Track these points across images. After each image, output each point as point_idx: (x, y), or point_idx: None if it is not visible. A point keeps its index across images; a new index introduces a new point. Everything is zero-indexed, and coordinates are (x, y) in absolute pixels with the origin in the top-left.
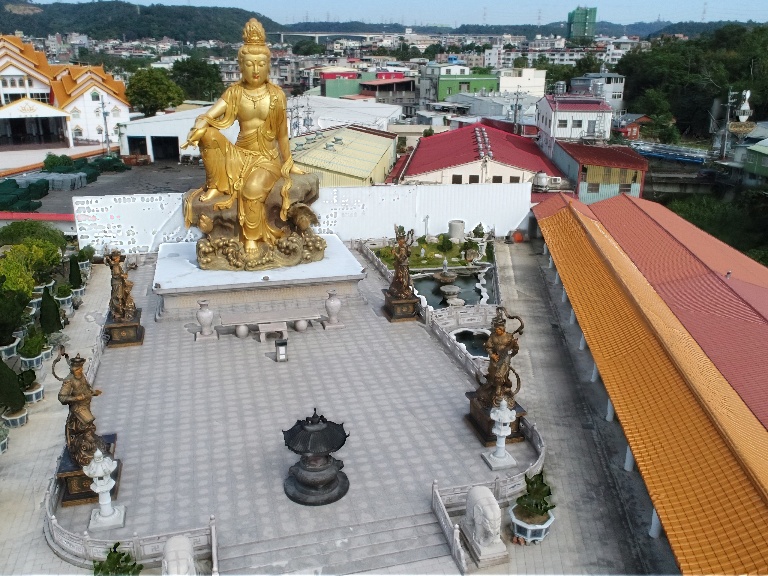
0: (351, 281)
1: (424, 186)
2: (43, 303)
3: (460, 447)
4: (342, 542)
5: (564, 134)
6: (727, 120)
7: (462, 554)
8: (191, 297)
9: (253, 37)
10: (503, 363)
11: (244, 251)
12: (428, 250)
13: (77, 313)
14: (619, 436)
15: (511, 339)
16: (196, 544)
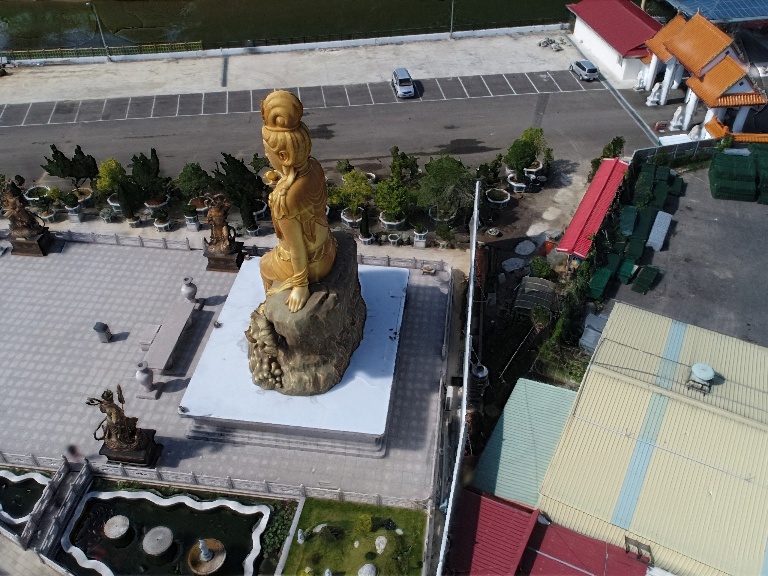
0: None
1: (438, 575)
2: None
3: None
4: None
5: None
6: None
7: None
8: None
9: None
10: None
11: None
12: None
13: None
14: None
15: None
16: None
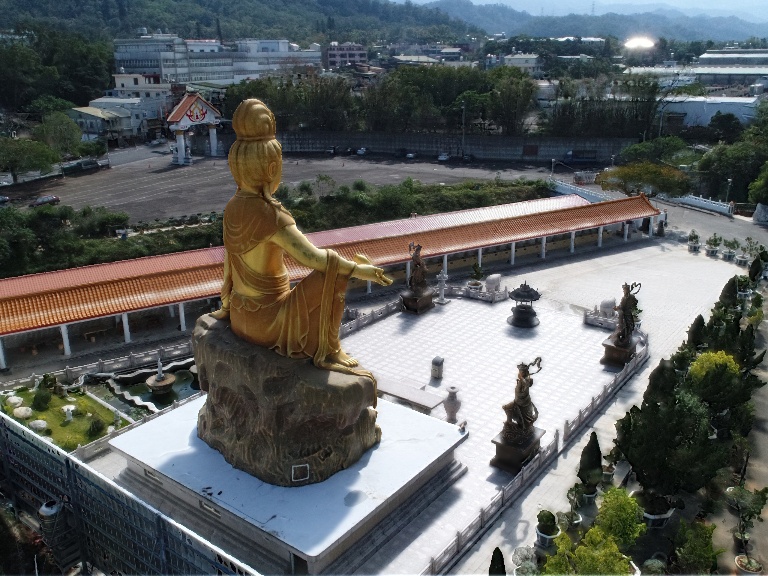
0: None
1: None
2: None
3: None
4: None
5: None
6: None
7: None
8: None
9: None
10: None
11: None
12: (48, 418)
13: None
14: (383, 289)
15: None
16: (592, 323)
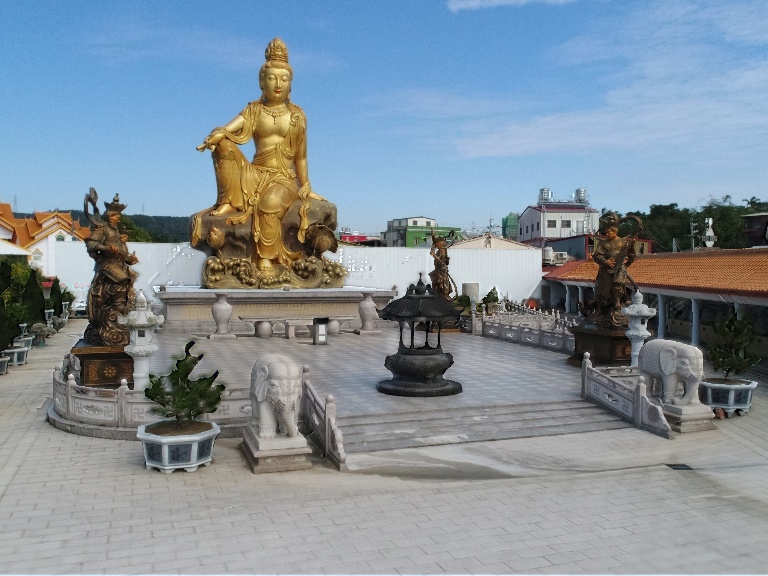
0: (380, 300)
1: None
2: (27, 289)
3: (579, 374)
4: (481, 418)
5: (554, 234)
6: (692, 249)
7: (659, 408)
8: (199, 307)
9: (277, 52)
10: (620, 270)
11: (258, 269)
12: None
13: (57, 334)
14: (762, 367)
15: (626, 243)
16: None
